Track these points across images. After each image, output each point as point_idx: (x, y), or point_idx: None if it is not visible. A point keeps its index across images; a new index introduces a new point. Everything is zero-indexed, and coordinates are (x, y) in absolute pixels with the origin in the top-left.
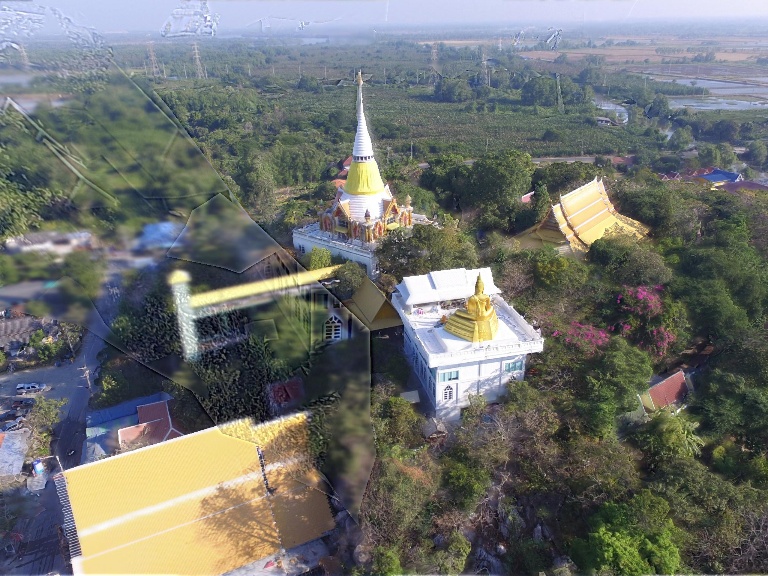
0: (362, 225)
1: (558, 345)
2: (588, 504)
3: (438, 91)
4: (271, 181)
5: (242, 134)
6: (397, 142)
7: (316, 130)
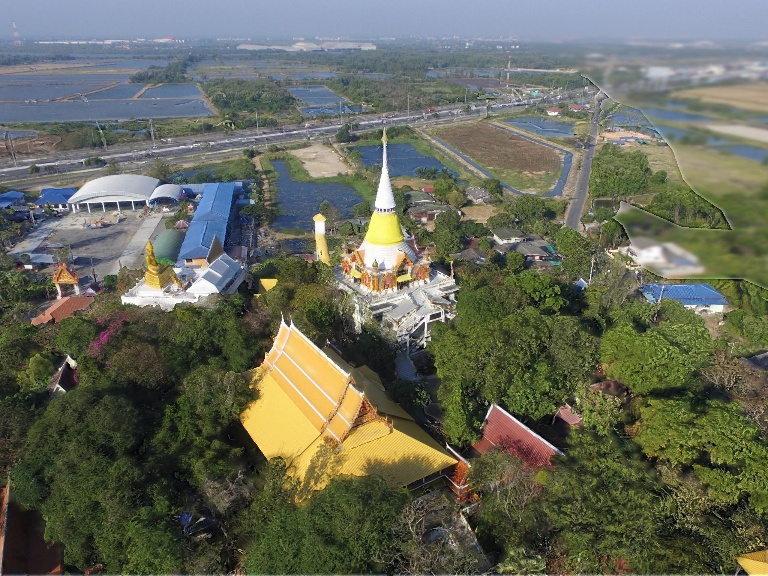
0: None
1: (117, 307)
2: None
3: None
4: None
5: None
6: None
7: None
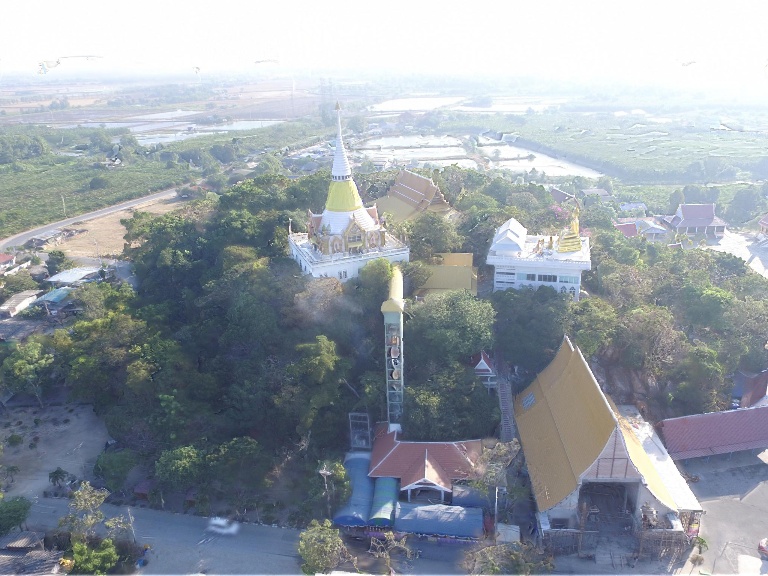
0: (379, 232)
1: None
2: (679, 292)
3: None
4: None
5: None
6: None
7: None
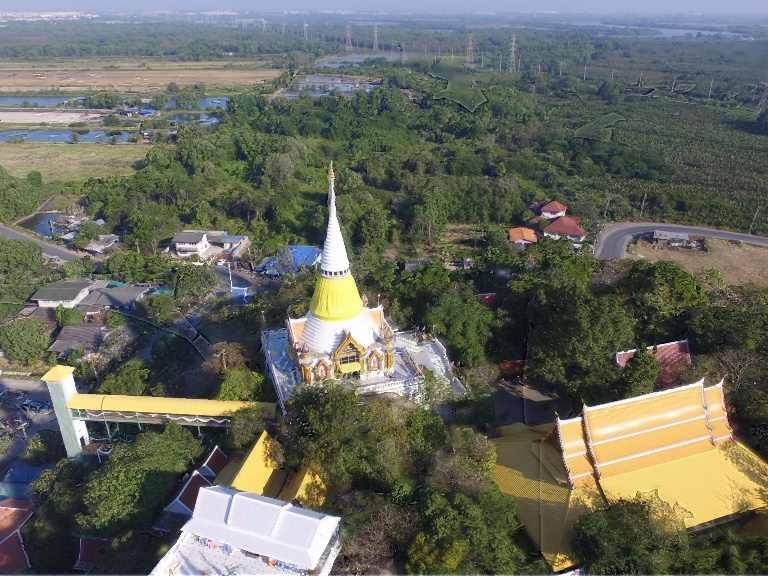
0: None
1: None
2: None
3: (762, 119)
4: (440, 217)
5: (479, 148)
6: (645, 186)
7: (562, 154)
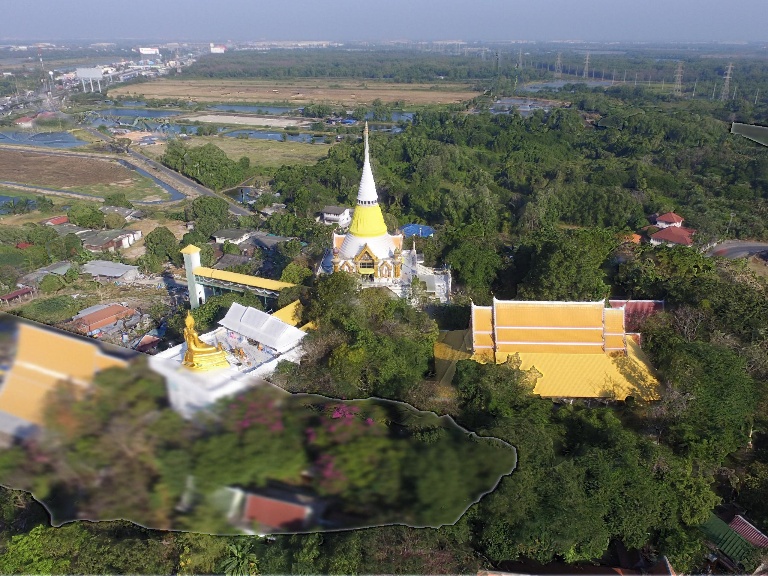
0: None
1: None
2: None
3: None
4: (550, 215)
5: None
6: None
7: (719, 177)
